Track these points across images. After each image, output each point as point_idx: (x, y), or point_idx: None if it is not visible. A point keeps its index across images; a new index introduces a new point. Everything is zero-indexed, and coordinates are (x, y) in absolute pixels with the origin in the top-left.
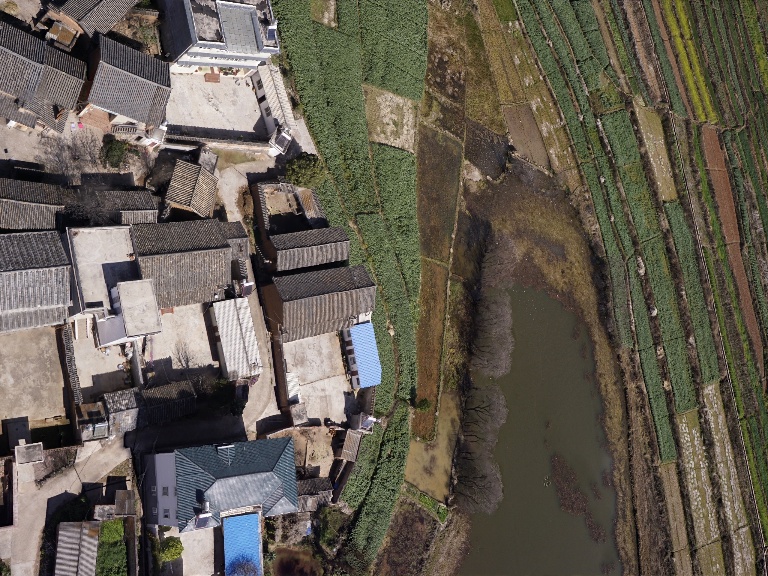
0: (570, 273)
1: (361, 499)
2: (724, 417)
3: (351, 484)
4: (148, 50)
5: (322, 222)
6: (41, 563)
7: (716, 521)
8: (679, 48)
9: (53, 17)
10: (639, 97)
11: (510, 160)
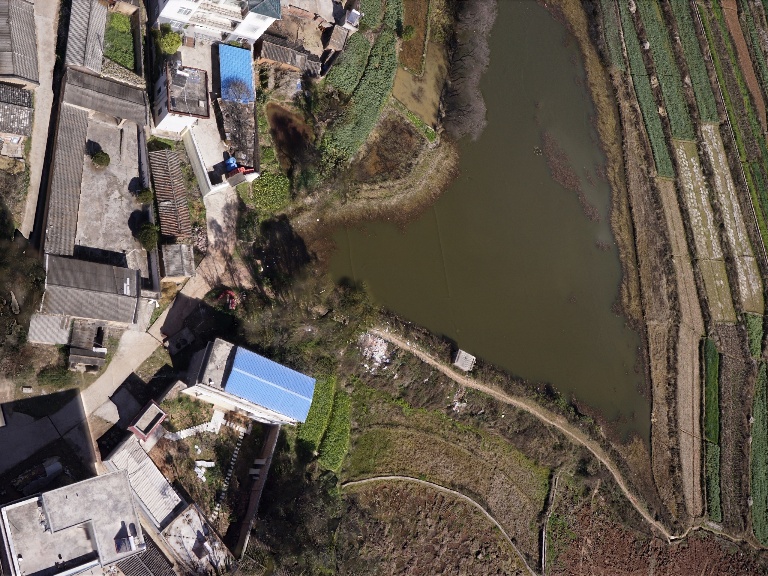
0: None
1: (350, 90)
2: (725, 157)
3: (340, 74)
4: None
5: None
6: (59, 22)
7: (719, 244)
8: None
9: None
10: None
11: None
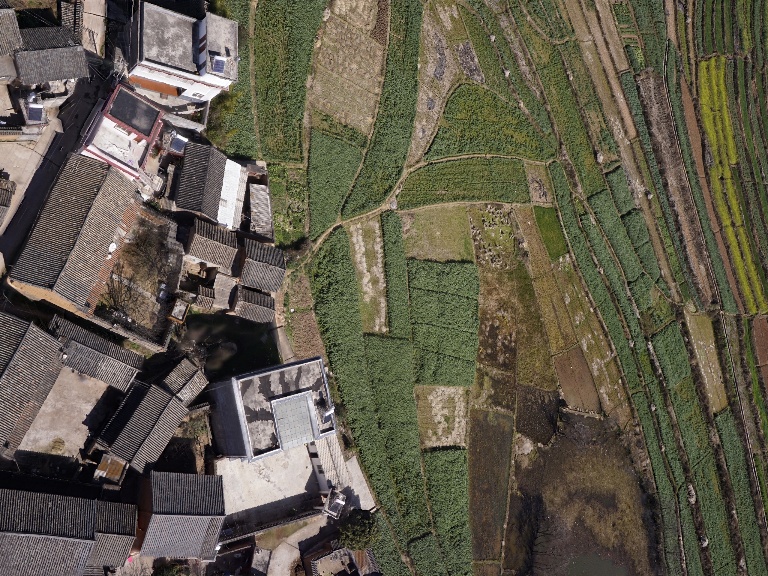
0: (621, 523)
1: None
2: None
3: None
4: (198, 443)
5: None
6: None
7: None
8: (730, 239)
9: (101, 447)
10: (690, 303)
11: (561, 417)
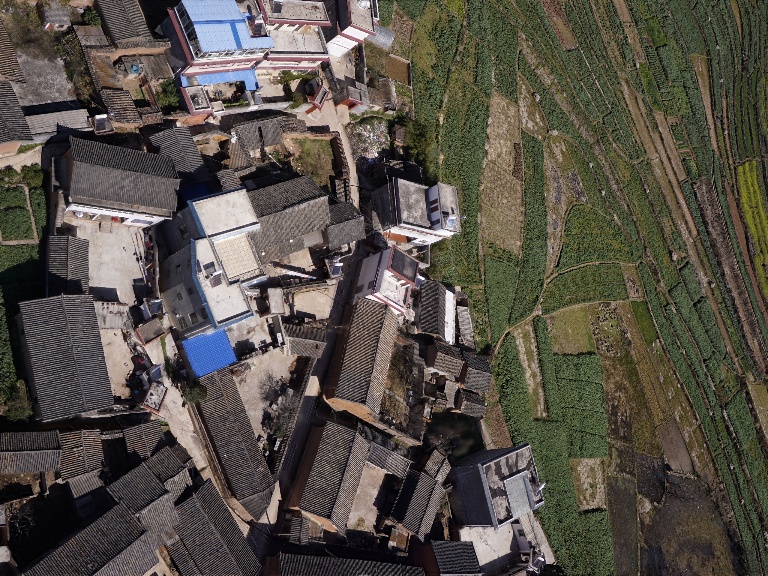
0: (718, 568)
1: None
2: None
3: None
4: (444, 516)
5: None
6: None
7: None
8: None
9: (389, 523)
10: (749, 374)
11: (668, 479)
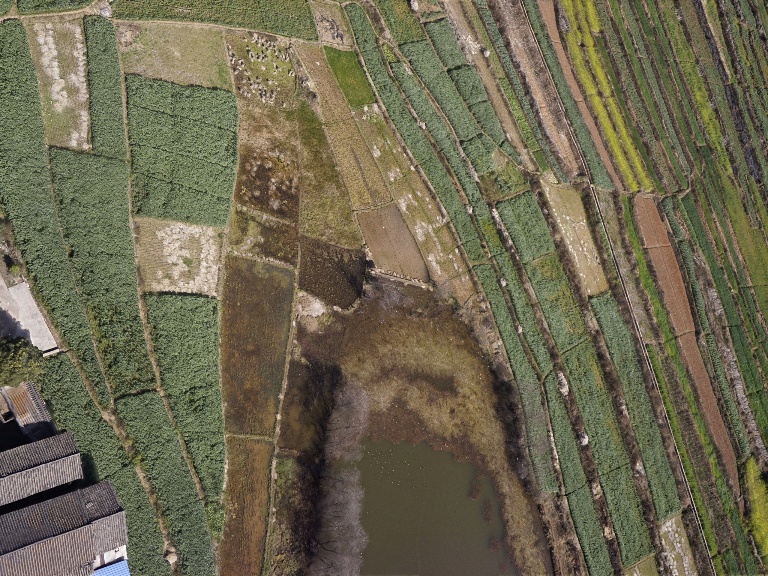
0: (463, 411)
1: None
2: (691, 557)
3: None
4: None
5: (45, 427)
6: None
7: None
8: (597, 108)
9: None
10: (549, 173)
11: (368, 280)
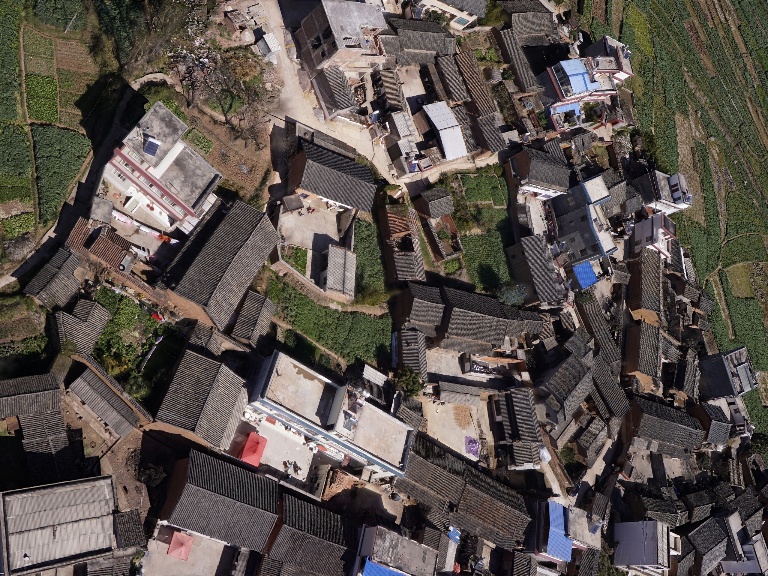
0: None
1: None
2: None
3: None
4: None
5: (767, 472)
6: None
7: None
8: None
9: (672, 392)
10: None
11: None
